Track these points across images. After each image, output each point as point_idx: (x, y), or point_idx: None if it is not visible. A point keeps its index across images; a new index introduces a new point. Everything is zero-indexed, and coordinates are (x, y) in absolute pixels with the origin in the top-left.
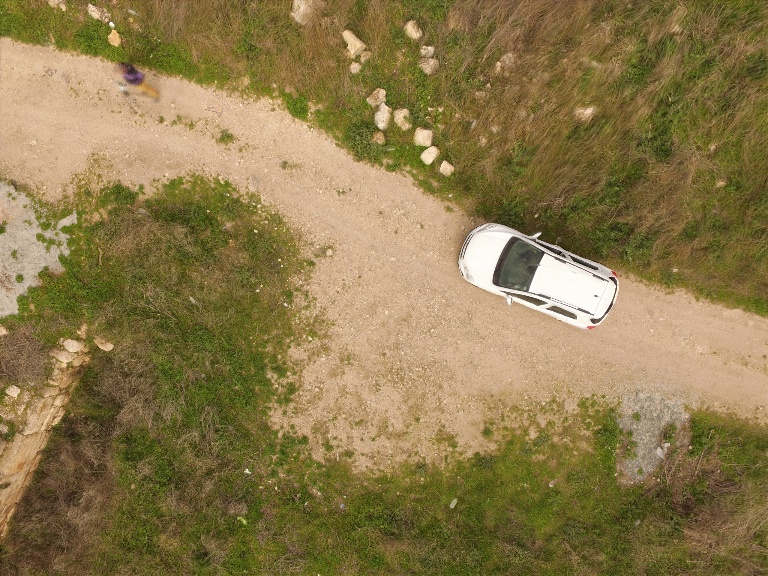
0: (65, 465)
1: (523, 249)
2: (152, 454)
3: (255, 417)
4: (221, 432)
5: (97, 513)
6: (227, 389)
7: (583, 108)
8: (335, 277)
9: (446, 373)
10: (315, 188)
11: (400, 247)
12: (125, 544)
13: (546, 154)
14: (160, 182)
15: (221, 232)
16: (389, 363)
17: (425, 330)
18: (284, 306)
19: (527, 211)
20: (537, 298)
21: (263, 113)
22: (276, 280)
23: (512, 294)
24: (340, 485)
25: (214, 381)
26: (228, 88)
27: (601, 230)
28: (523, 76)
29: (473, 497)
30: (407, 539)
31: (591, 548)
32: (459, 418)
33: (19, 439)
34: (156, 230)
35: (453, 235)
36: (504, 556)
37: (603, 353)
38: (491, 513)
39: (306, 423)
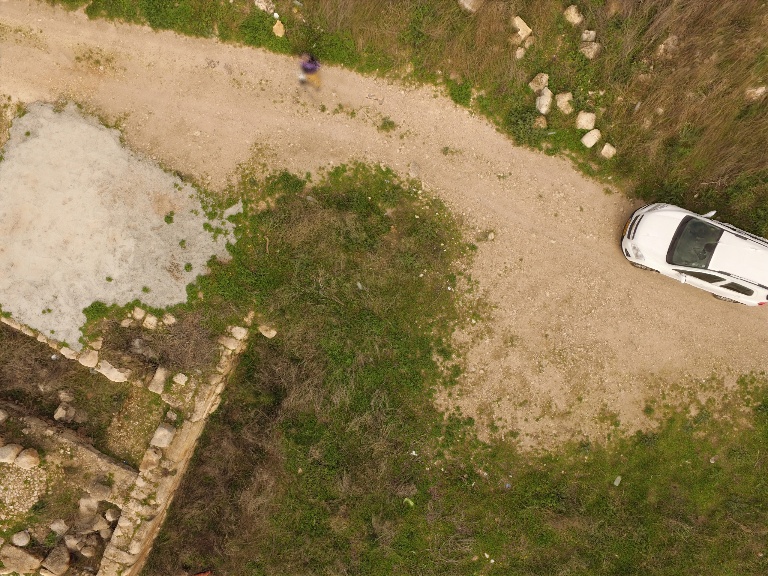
0: (224, 452)
1: (696, 228)
2: (321, 438)
3: (421, 400)
4: (390, 415)
5: (269, 497)
6: (394, 373)
7: (755, 87)
8: (497, 260)
9: (607, 353)
10: (476, 173)
11: (560, 229)
12: (293, 528)
13: (716, 134)
14: (325, 170)
15: (383, 218)
16: (551, 344)
17: (586, 311)
18: (448, 290)
19: (687, 191)
20: (716, 275)
21: (425, 100)
22: (439, 264)
23: (686, 272)
24: (506, 465)
25: (382, 365)
26: (390, 76)
27: (762, 208)
28: (690, 57)
29: (636, 474)
30: (577, 516)
31: (754, 522)
32: (620, 397)
33: (188, 426)
34: (329, 216)
35: (612, 217)
36: (669, 532)
37: (761, 330)
38: (654, 490)
39: (471, 405)
